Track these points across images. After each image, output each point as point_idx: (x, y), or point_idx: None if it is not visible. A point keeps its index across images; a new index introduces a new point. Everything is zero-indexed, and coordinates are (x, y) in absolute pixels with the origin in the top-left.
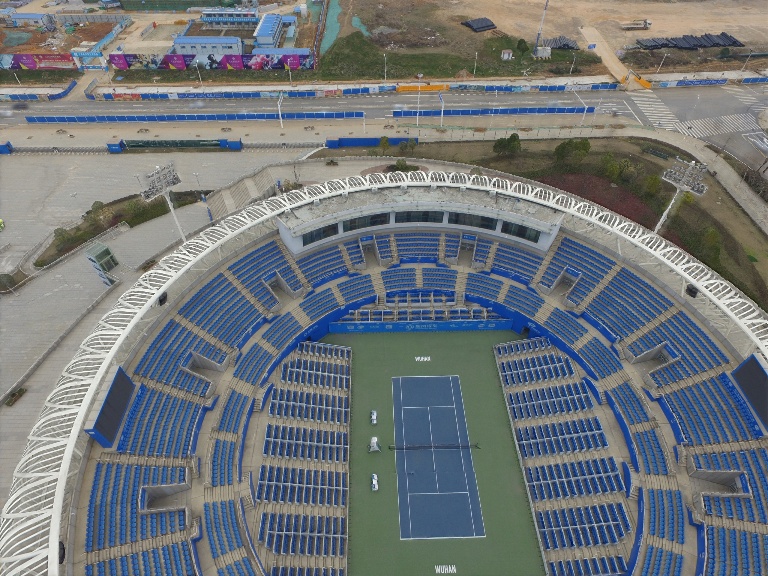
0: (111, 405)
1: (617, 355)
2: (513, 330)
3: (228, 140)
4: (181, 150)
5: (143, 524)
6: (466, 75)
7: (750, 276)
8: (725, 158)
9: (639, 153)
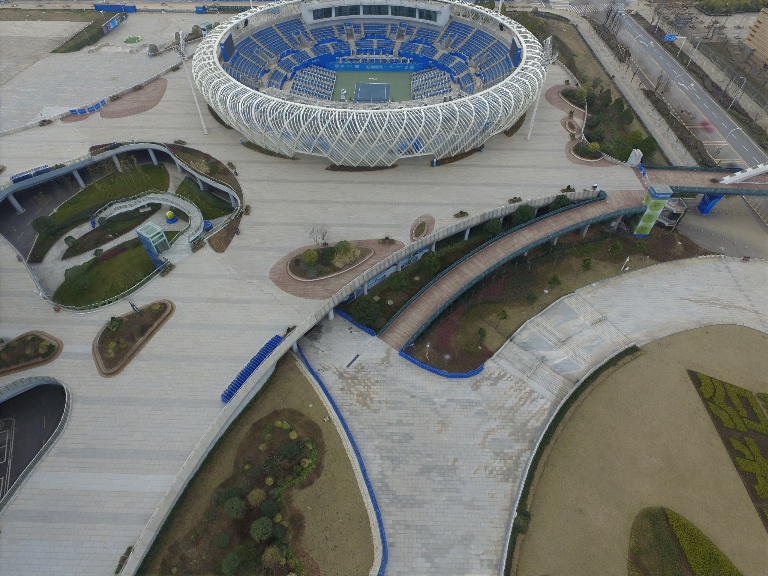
0: (228, 44)
1: (467, 65)
2: None
3: None
4: None
5: None
6: None
7: (567, 60)
8: (589, 21)
9: (532, 15)
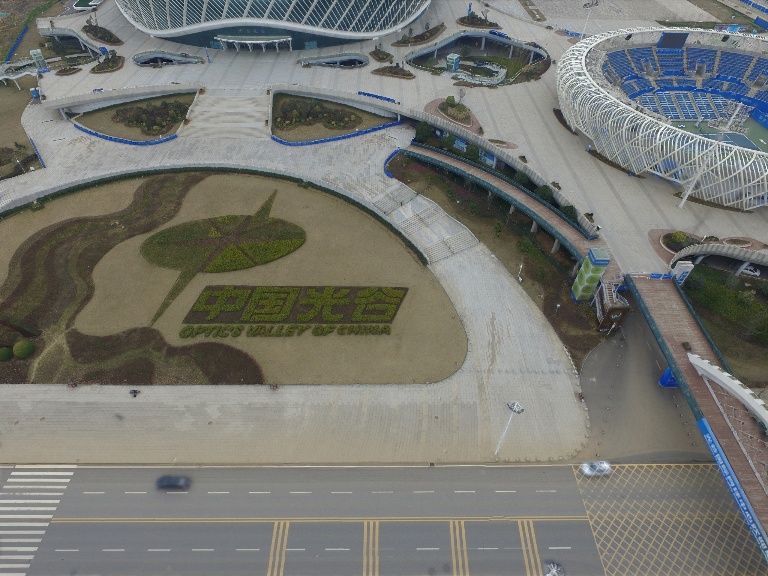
0: (674, 38)
1: None
2: None
3: None
4: None
5: (638, 62)
6: None
7: None
8: None
9: None
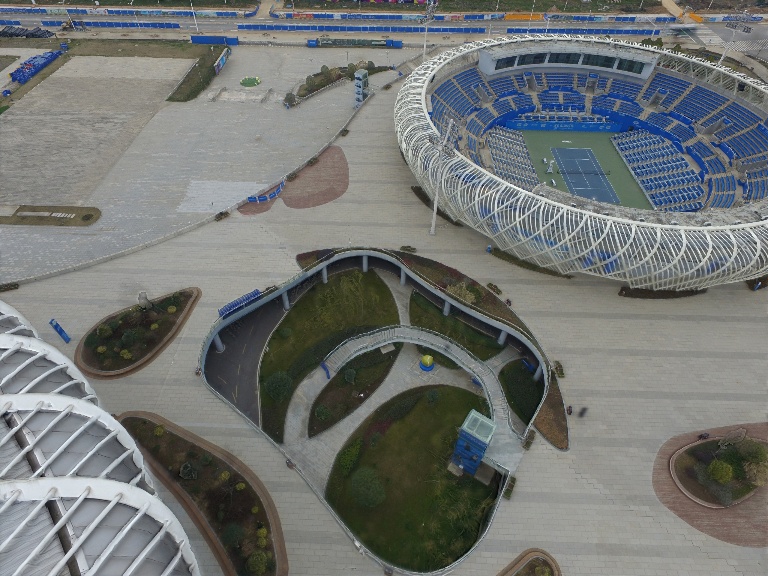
0: None
1: (693, 130)
2: (621, 132)
3: (394, 40)
4: (358, 47)
5: None
6: (556, 10)
7: None
8: (760, 62)
9: None
